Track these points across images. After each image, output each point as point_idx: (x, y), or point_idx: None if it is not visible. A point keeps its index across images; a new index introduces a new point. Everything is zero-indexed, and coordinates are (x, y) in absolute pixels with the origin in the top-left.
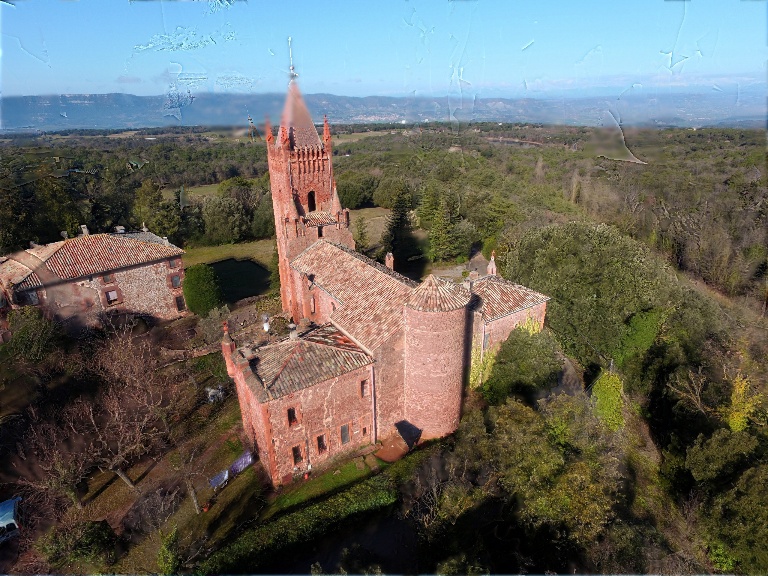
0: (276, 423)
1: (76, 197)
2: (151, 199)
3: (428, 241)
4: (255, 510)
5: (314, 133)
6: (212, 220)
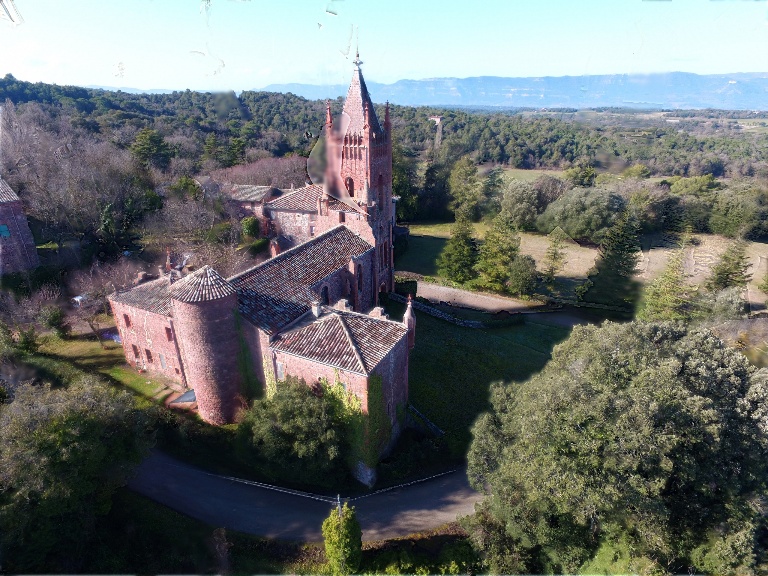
0: (120, 319)
1: (413, 160)
2: (463, 172)
3: (642, 295)
4: (106, 365)
5: (361, 121)
6: (504, 203)
